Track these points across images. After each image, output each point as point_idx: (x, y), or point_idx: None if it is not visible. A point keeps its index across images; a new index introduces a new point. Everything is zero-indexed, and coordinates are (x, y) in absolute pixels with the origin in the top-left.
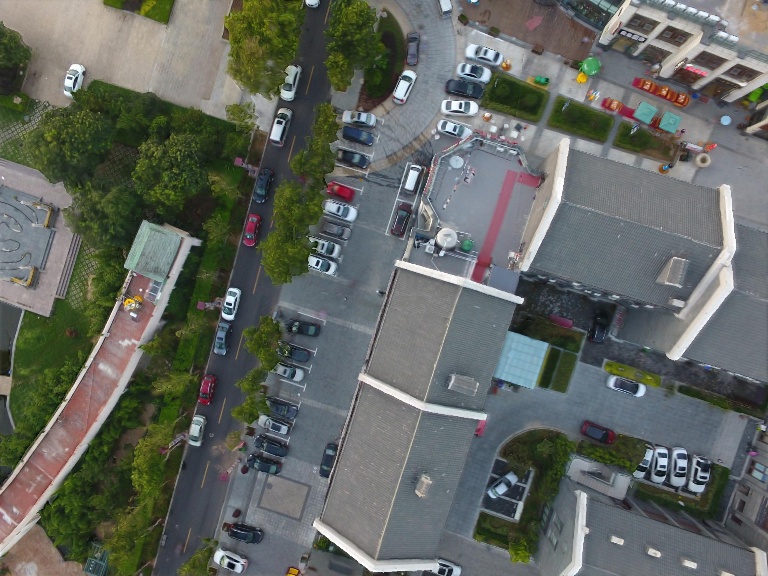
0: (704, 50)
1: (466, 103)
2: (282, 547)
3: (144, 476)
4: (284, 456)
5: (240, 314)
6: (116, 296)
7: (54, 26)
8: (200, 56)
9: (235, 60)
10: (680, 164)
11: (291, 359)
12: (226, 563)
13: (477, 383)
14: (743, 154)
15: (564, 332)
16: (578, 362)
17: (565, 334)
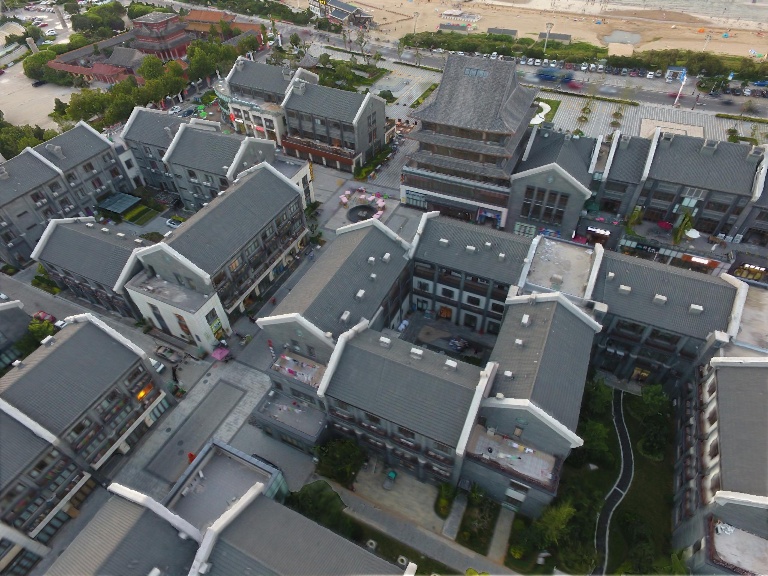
0: (252, 114)
1: None
2: None
3: None
4: None
5: None
6: None
7: None
8: None
9: None
10: None
11: None
12: None
13: None
14: None
15: None
16: (159, 217)
17: None
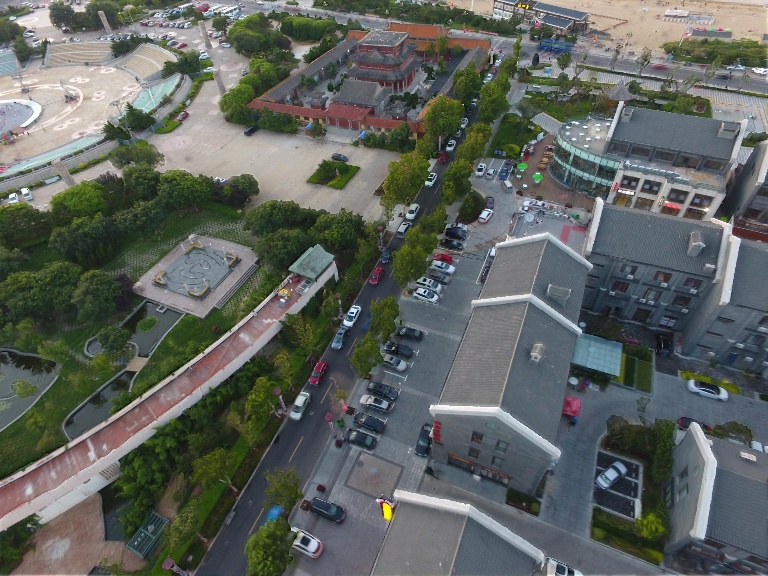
0: (671, 188)
1: None
2: (365, 534)
3: (261, 396)
4: (380, 434)
5: (357, 325)
6: (274, 289)
7: (274, 189)
8: (357, 202)
9: (390, 180)
10: None
11: (396, 356)
12: (300, 537)
13: (570, 289)
14: None
15: (634, 348)
16: (655, 371)
17: (635, 349)
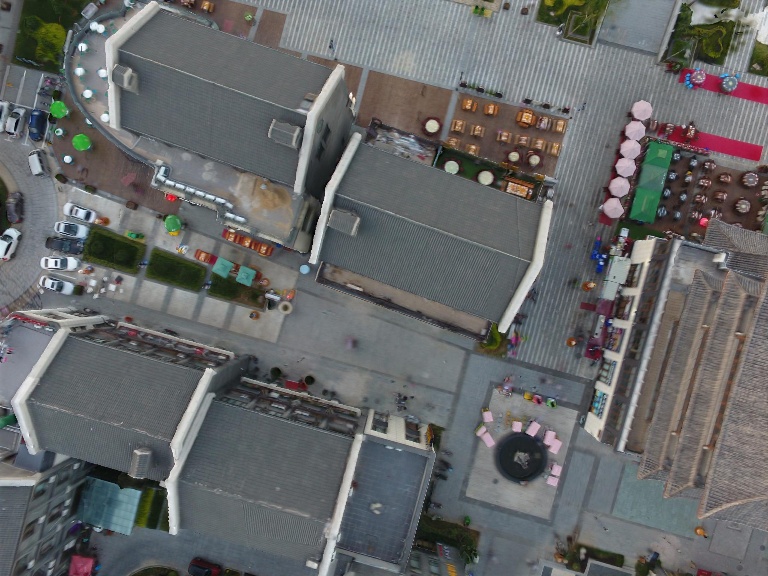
0: None
1: (63, 260)
2: None
3: None
4: None
5: None
6: None
7: None
8: None
9: None
10: (269, 310)
11: None
12: None
13: None
14: (327, 299)
15: None
16: None
17: None
